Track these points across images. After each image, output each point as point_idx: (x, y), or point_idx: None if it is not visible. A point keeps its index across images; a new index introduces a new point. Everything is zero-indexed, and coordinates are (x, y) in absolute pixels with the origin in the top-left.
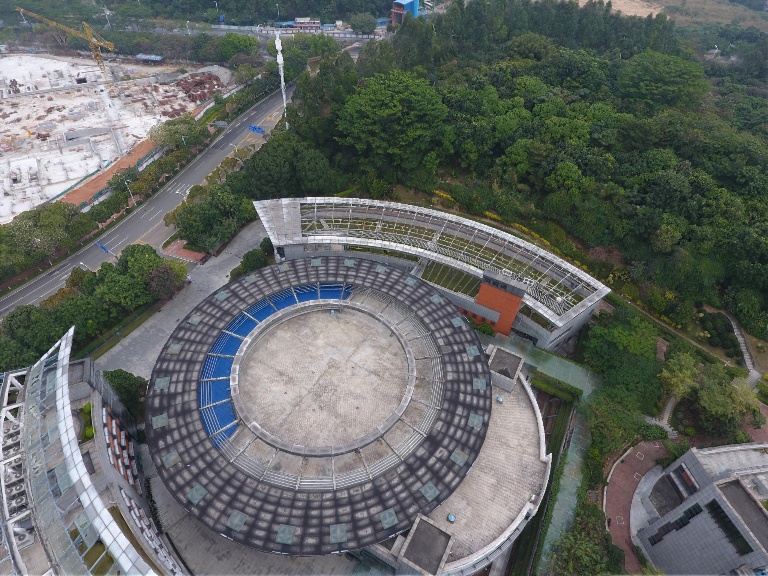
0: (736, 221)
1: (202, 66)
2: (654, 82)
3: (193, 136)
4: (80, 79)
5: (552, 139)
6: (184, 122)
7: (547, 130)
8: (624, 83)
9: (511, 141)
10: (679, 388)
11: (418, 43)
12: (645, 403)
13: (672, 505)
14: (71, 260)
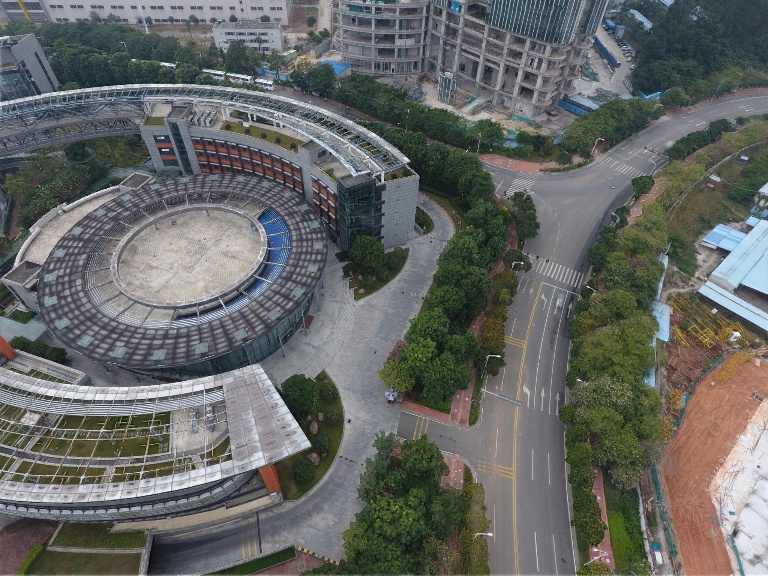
0: None
1: None
2: None
3: None
4: None
5: None
6: None
7: None
8: None
9: None
10: None
11: None
12: None
13: None
14: None
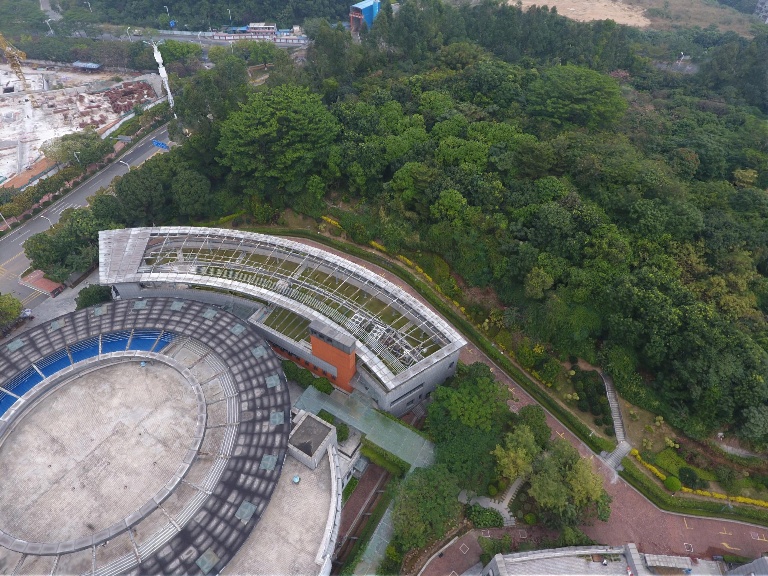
0: (620, 264)
1: (139, 74)
2: (562, 99)
3: (88, 152)
4: (8, 88)
5: (445, 162)
6: (84, 137)
7: (440, 152)
8: (532, 100)
9: (399, 164)
10: (510, 471)
11: (330, 53)
12: (473, 486)
13: None
14: None
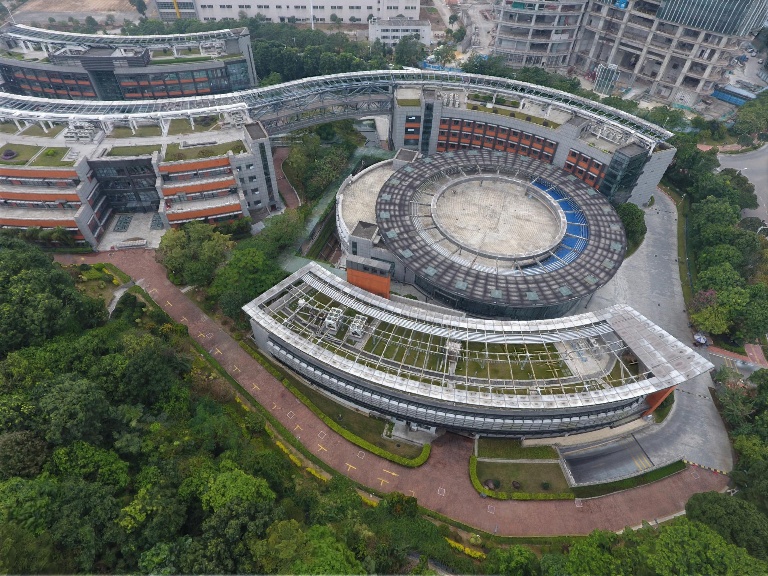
0: None
1: None
2: None
3: None
4: None
5: None
6: None
7: None
8: None
9: None
10: None
11: None
12: None
13: (256, 214)
14: None
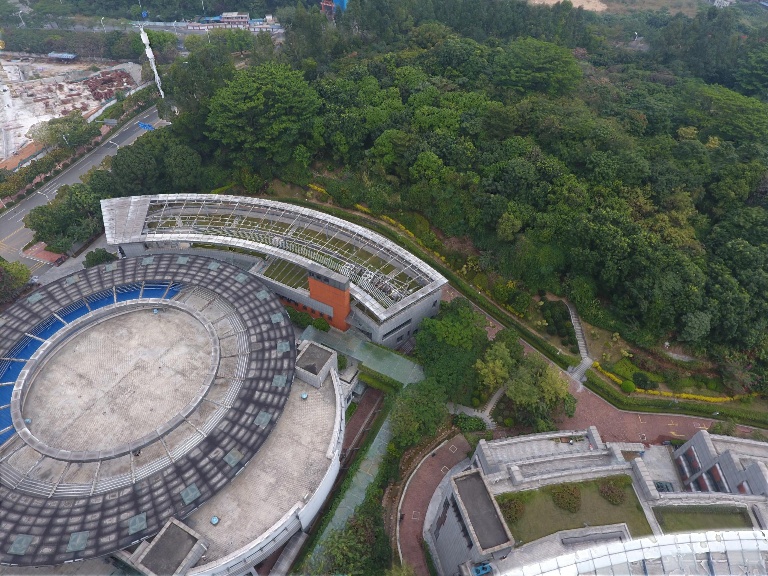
0: (578, 207)
1: (116, 63)
2: (525, 69)
3: (76, 135)
4: None
5: (421, 129)
6: (70, 121)
7: (416, 120)
8: (497, 71)
9: (379, 132)
10: (490, 379)
11: (307, 35)
12: (459, 395)
13: None
14: None
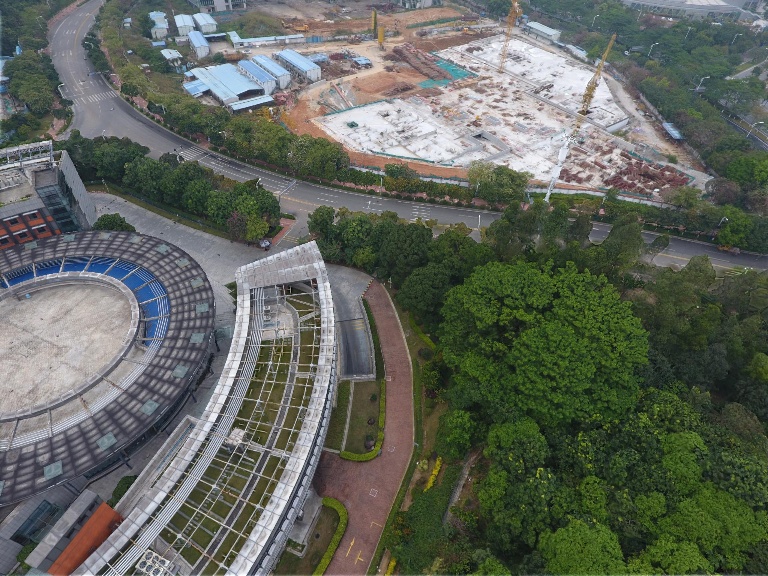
0: None
1: (701, 169)
2: None
3: (490, 190)
4: (588, 111)
5: None
6: (513, 177)
7: None
8: None
9: (525, 573)
10: None
11: None
12: None
13: None
14: (303, 184)
